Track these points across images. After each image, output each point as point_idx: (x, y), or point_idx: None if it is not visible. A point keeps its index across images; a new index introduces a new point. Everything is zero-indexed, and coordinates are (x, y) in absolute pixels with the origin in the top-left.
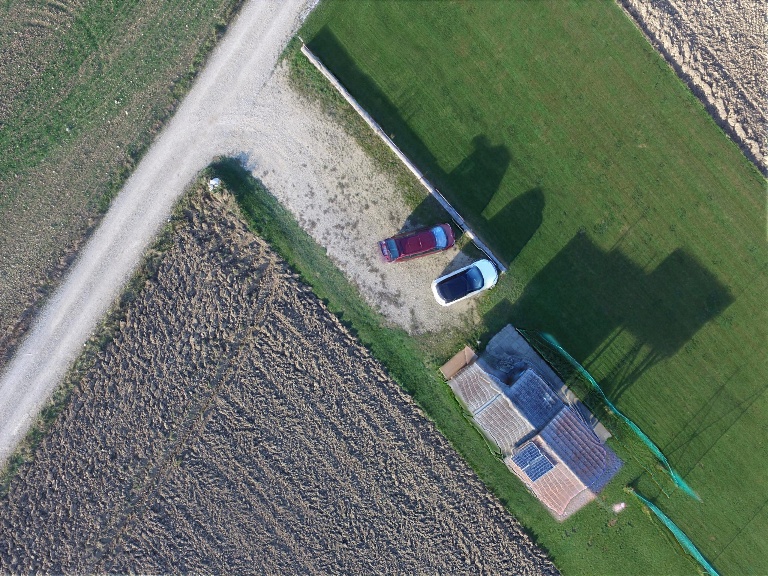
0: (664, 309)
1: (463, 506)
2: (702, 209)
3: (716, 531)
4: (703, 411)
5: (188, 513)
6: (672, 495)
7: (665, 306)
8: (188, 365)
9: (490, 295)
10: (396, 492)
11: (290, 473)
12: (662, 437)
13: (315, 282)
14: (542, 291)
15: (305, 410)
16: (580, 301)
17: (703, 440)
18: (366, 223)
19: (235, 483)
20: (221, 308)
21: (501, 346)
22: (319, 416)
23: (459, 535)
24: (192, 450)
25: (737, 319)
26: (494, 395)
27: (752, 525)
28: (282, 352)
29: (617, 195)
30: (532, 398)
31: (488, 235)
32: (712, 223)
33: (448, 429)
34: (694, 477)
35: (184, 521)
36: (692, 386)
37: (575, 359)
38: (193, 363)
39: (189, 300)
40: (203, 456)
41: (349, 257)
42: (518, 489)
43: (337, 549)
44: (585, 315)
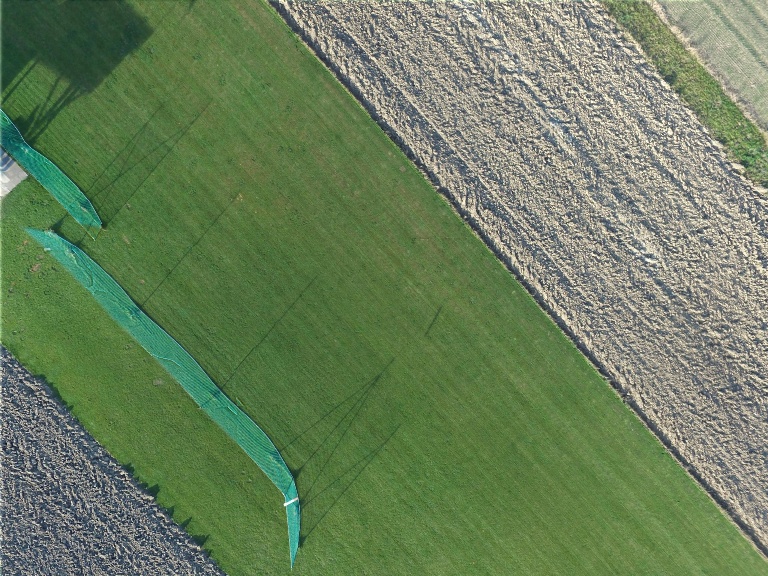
0: (79, 41)
1: None
2: None
3: (145, 273)
4: (127, 149)
5: None
6: (97, 237)
7: (80, 38)
8: None
9: None
10: None
11: None
12: (84, 177)
13: None
14: None
15: None
16: None
17: (128, 179)
18: None
19: None
20: None
21: None
22: None
23: None
24: None
25: (156, 52)
26: None
27: (182, 266)
28: None
29: None
30: None
31: None
32: None
33: None
34: (121, 218)
35: None
36: (114, 123)
37: None
38: None
39: None
40: None
41: None
42: None
43: None
44: None
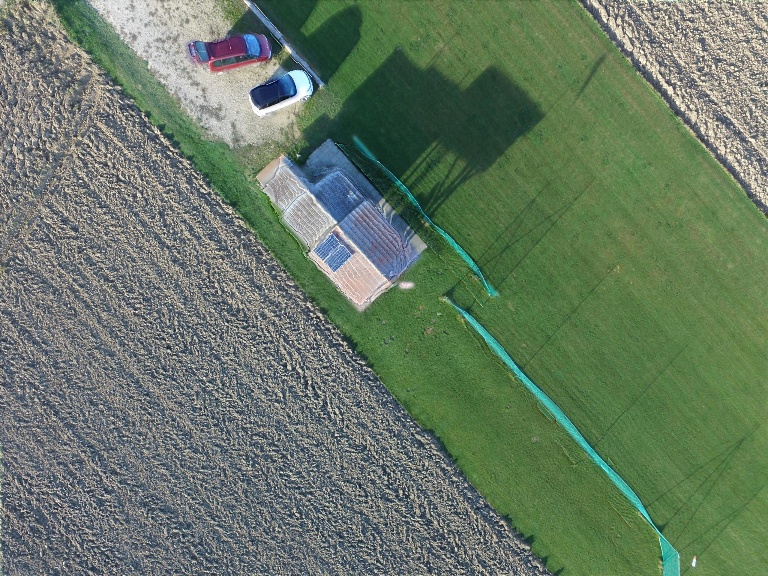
0: (477, 124)
1: (284, 314)
2: (513, 26)
3: (527, 338)
4: (515, 223)
5: (14, 318)
6: (485, 304)
7: (478, 121)
8: (11, 173)
9: (309, 109)
10: (219, 301)
11: (114, 281)
12: (476, 248)
13: (137, 95)
14: (360, 106)
15: (129, 220)
16: (397, 117)
17: (515, 251)
18: (187, 37)
19: (60, 290)
20: (43, 118)
21: (321, 160)
22: (142, 225)
23: (280, 342)
24: (17, 257)
25: (547, 133)
26: (300, 193)
27: (561, 332)
28: (105, 163)
29: (432, 12)
30: (335, 194)
31: (307, 50)
32: (523, 40)
33: (269, 240)
34: (506, 287)
35: (9, 325)
36: (505, 199)
37: (393, 173)
38: (17, 172)
39: (10, 109)
40: (28, 263)
41: (170, 70)
42: (334, 295)
43: (161, 354)
44: (402, 130)
